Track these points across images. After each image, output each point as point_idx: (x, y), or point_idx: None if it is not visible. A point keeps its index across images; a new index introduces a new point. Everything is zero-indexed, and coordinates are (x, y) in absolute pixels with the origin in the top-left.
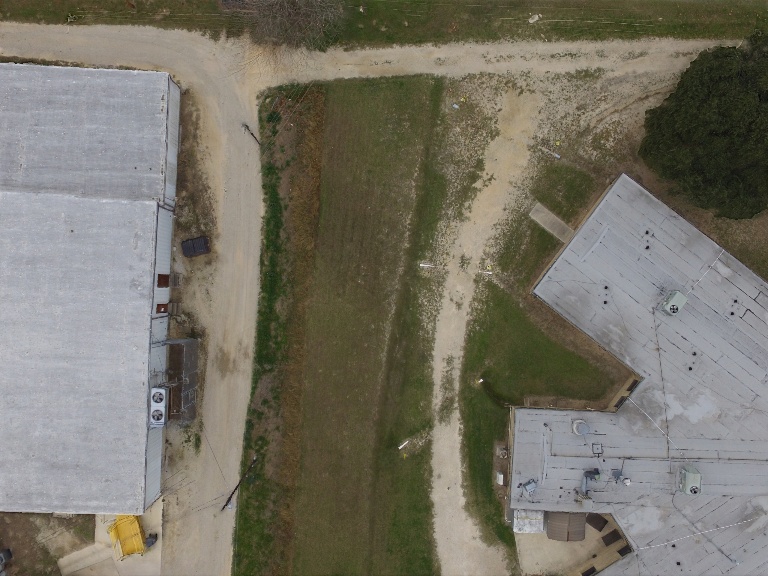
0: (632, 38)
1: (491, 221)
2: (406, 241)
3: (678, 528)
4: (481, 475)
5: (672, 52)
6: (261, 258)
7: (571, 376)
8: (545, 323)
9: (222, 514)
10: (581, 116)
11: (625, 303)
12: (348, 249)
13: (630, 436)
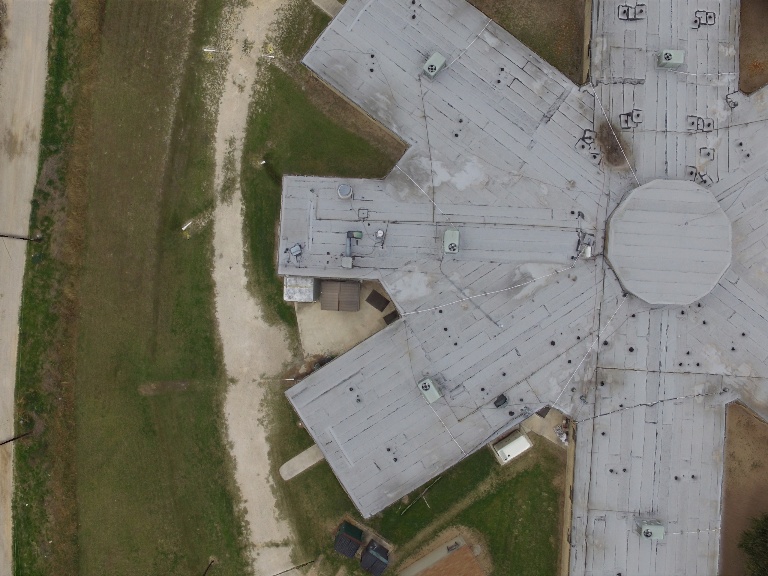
0: None
1: (274, 6)
2: (191, 27)
3: (446, 295)
4: (263, 255)
5: None
6: (49, 43)
7: (352, 157)
8: (327, 106)
9: (8, 293)
10: None
11: (392, 72)
12: (134, 34)
13: (397, 202)
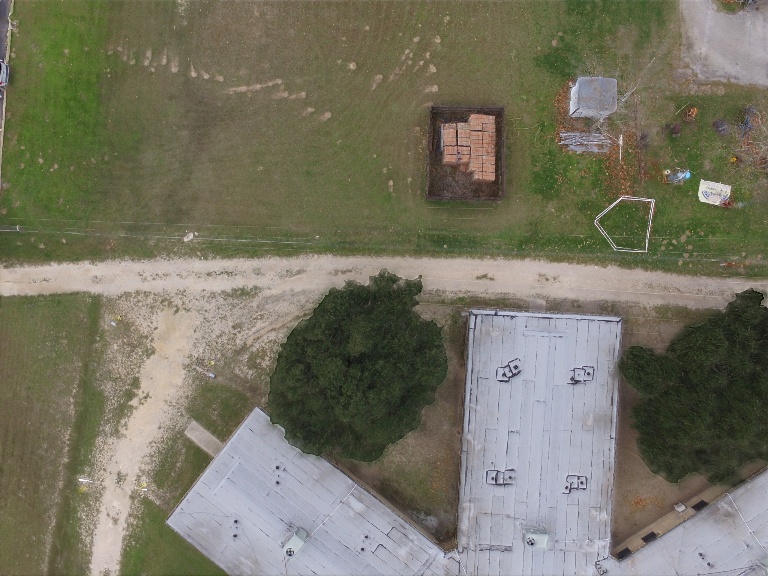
0: (290, 255)
1: (146, 439)
2: (65, 456)
3: None
4: None
5: (331, 270)
6: None
7: None
8: None
9: None
10: (237, 335)
11: (256, 536)
12: (9, 464)
13: None
